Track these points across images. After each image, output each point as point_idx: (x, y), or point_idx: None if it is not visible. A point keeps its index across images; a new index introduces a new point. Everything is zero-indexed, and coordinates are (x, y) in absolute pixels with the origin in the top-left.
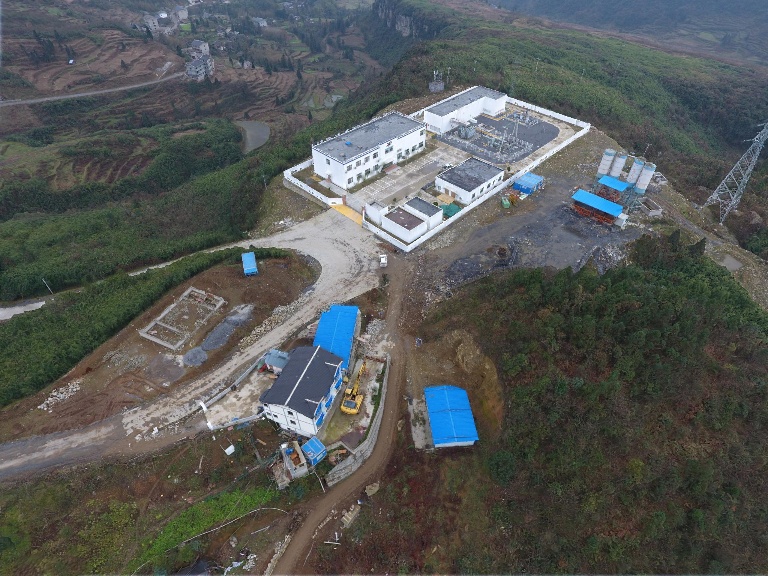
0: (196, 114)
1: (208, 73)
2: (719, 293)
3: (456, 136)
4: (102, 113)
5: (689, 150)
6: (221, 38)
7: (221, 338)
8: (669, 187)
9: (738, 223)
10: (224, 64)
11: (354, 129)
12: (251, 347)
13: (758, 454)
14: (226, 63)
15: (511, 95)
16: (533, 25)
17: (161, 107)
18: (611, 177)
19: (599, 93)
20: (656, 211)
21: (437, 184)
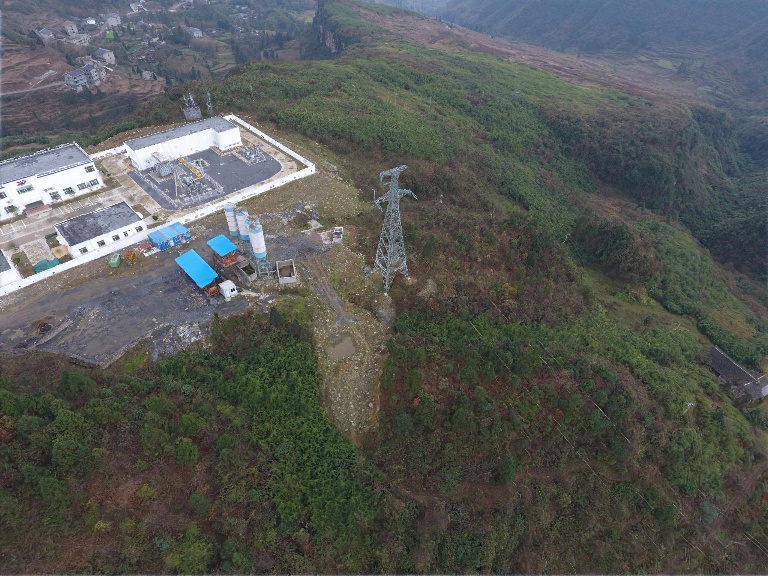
0: (67, 126)
1: (93, 83)
2: (270, 395)
3: (155, 173)
4: None
5: (518, 190)
6: (145, 47)
7: None
8: (343, 246)
9: (402, 294)
10: (123, 74)
11: (4, 163)
12: None
13: None
14: (125, 73)
15: (279, 126)
16: (454, 46)
17: (25, 117)
18: (240, 235)
19: (402, 126)
20: (287, 278)
21: (57, 233)
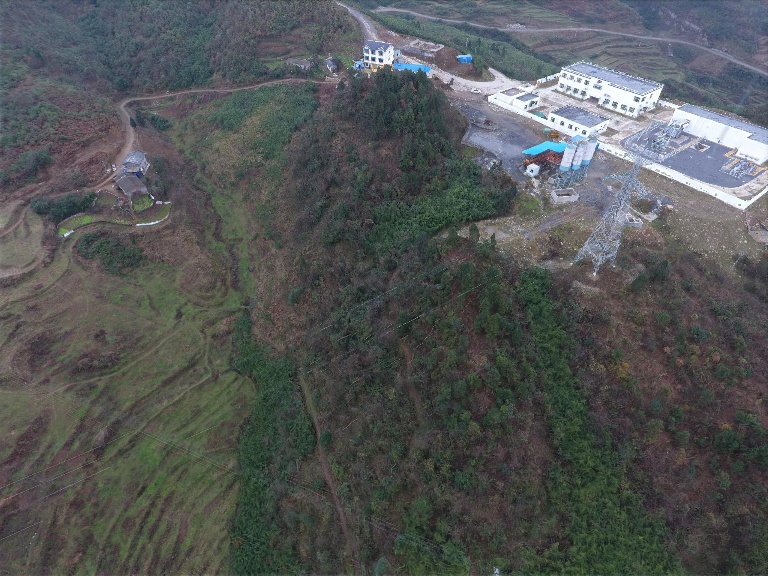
0: None
1: None
2: None
3: None
4: (764, 95)
5: None
6: None
7: (413, 51)
8: None
9: (572, 271)
10: None
11: (619, 73)
12: (411, 59)
13: (332, 173)
14: None
15: None
16: None
17: None
18: None
19: None
20: None
21: None
